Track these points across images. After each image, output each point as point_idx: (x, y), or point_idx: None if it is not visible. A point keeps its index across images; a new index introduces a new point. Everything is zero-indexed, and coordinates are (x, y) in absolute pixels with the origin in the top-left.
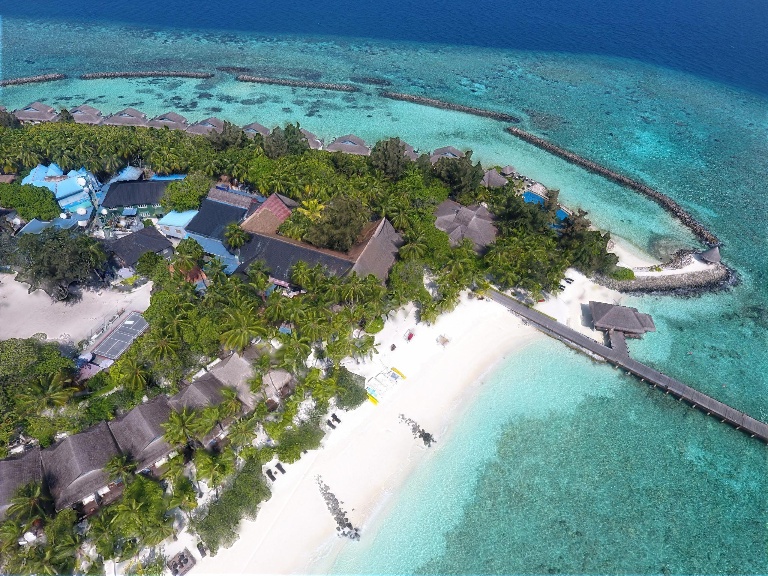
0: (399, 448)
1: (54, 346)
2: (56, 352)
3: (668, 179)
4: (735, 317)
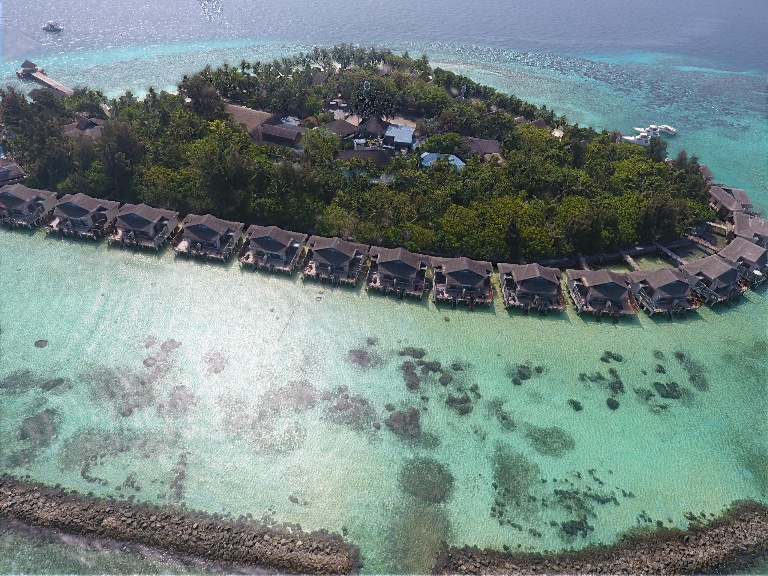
0: None
1: (351, 90)
2: (344, 81)
3: None
4: None
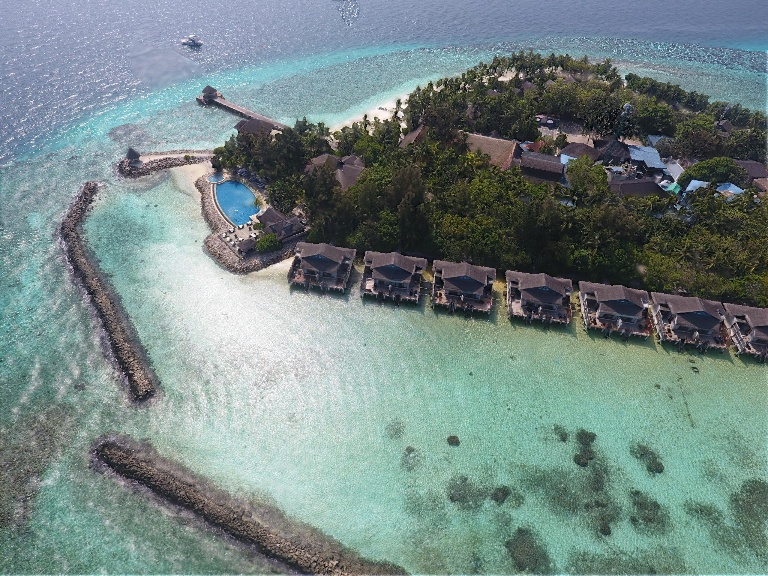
0: (393, 106)
1: (560, 105)
2: (552, 96)
3: (2, 267)
4: (163, 142)
